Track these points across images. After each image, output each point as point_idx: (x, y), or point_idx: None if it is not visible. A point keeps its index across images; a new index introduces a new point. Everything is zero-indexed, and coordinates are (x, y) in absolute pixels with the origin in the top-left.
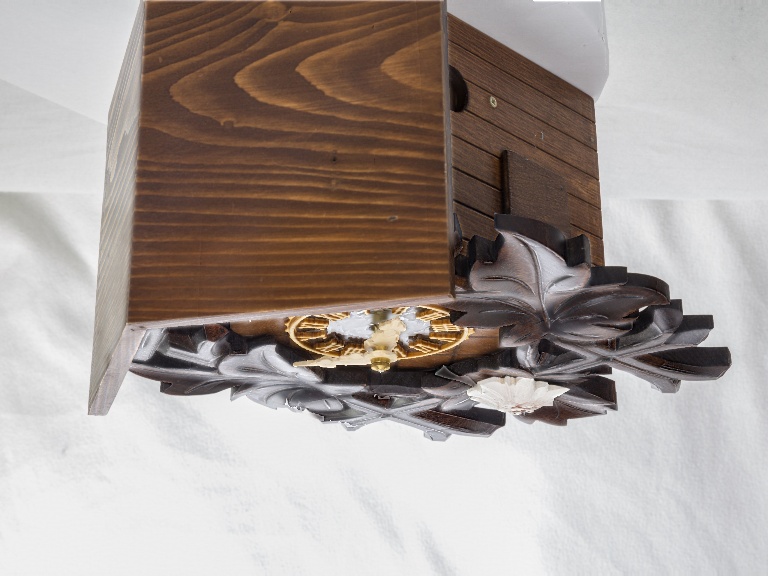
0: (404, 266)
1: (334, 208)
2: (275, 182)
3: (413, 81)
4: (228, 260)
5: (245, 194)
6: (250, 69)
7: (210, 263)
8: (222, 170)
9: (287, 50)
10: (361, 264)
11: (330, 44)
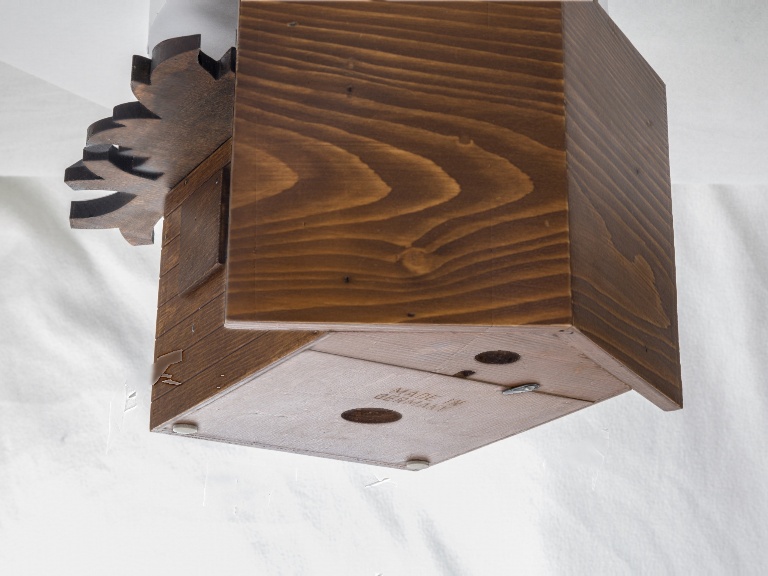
0: None
1: (351, 41)
2: (412, 74)
3: (264, 158)
4: (459, 4)
5: (444, 66)
6: (442, 197)
7: (478, 4)
8: (470, 93)
9: (401, 212)
10: None
11: (353, 212)
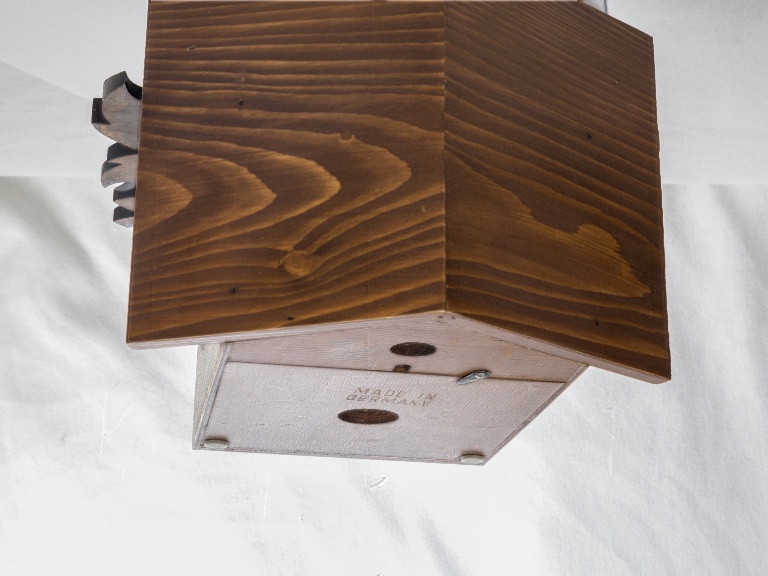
0: (185, 6)
1: (243, 55)
2: (299, 77)
3: (163, 182)
4: None
5: (328, 64)
6: (323, 196)
7: None
8: (352, 88)
9: (284, 217)
10: (222, 5)
11: (240, 223)
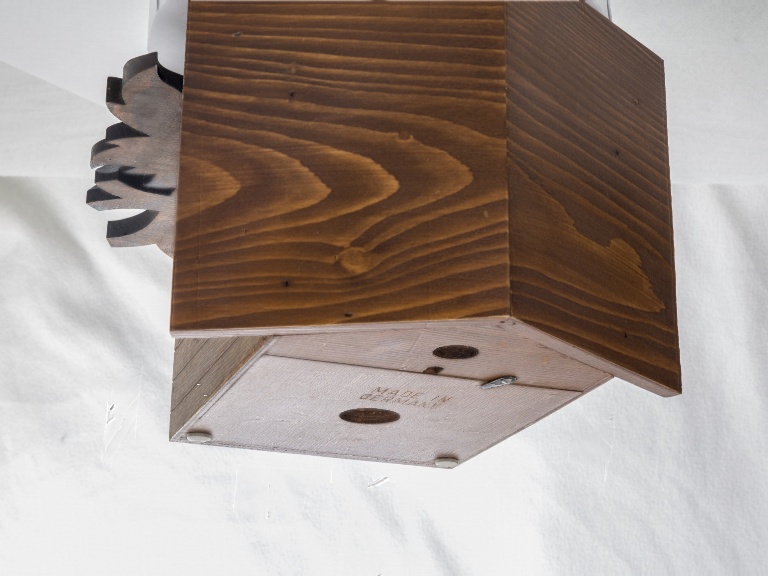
0: None
1: (294, 46)
2: (353, 73)
3: (208, 169)
4: None
5: (385, 63)
6: (381, 195)
7: None
8: (410, 88)
9: (340, 213)
10: None
11: (293, 216)
